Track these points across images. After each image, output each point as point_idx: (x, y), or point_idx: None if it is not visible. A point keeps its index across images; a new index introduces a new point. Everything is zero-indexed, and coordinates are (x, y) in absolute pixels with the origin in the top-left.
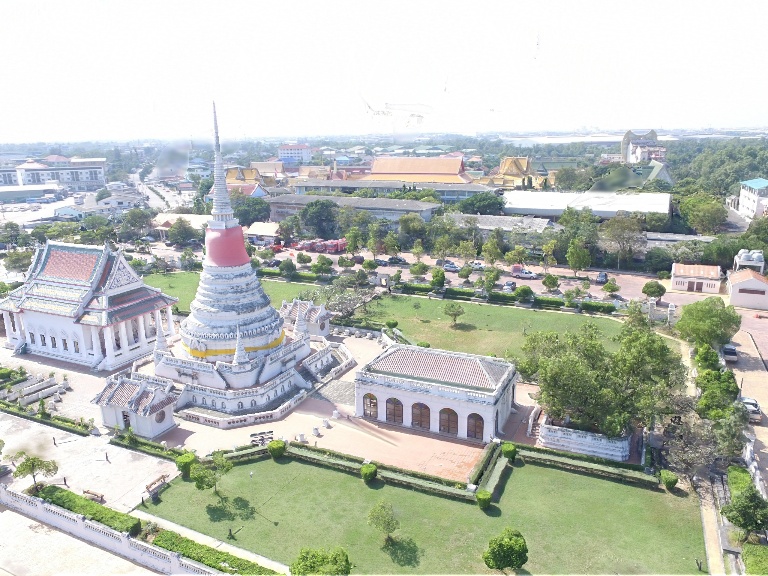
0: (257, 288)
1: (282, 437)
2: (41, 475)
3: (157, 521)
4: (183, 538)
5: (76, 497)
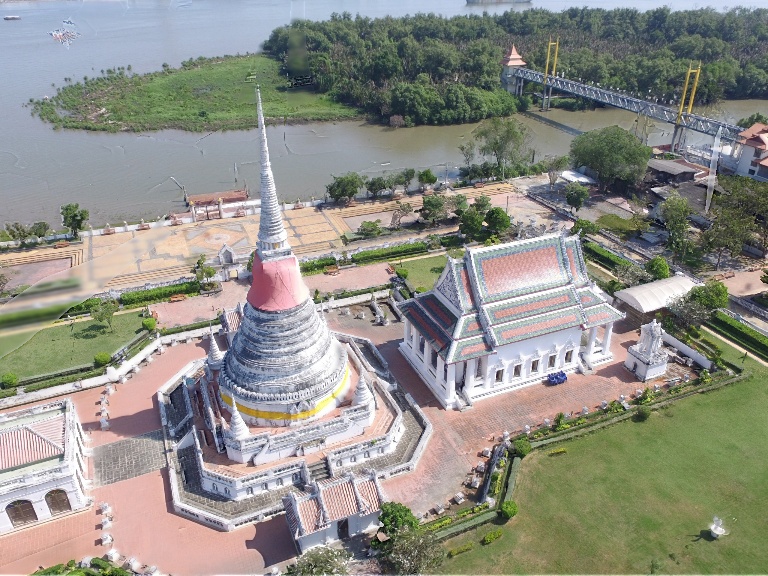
0: (245, 335)
1: (121, 376)
2: (233, 292)
3: (126, 312)
4: (84, 303)
5: (174, 288)
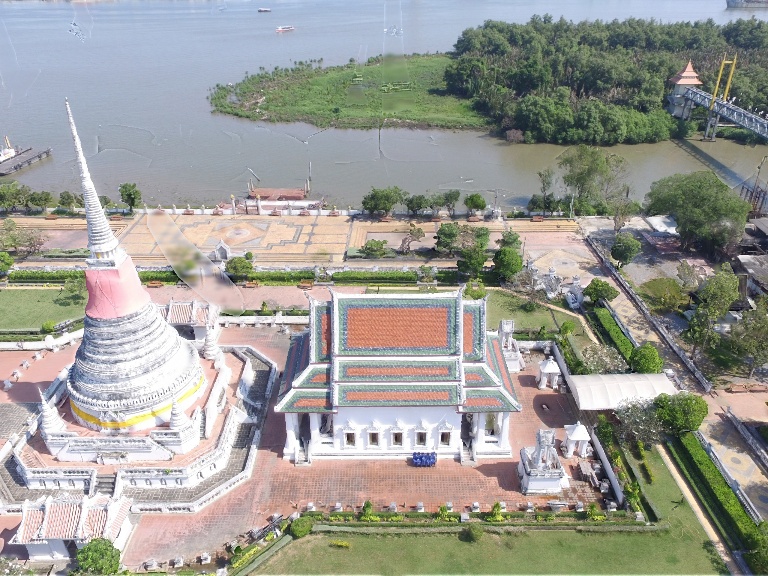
0: None
1: (53, 346)
2: None
3: None
4: (80, 273)
5: (157, 274)
